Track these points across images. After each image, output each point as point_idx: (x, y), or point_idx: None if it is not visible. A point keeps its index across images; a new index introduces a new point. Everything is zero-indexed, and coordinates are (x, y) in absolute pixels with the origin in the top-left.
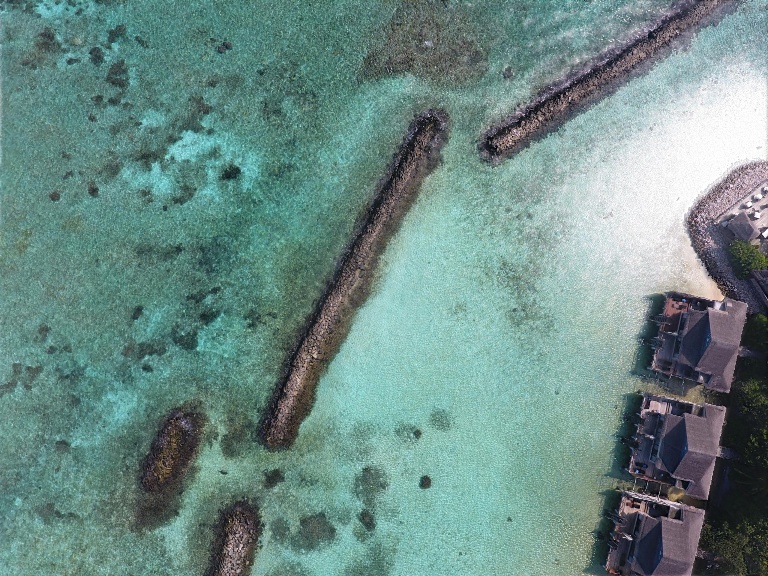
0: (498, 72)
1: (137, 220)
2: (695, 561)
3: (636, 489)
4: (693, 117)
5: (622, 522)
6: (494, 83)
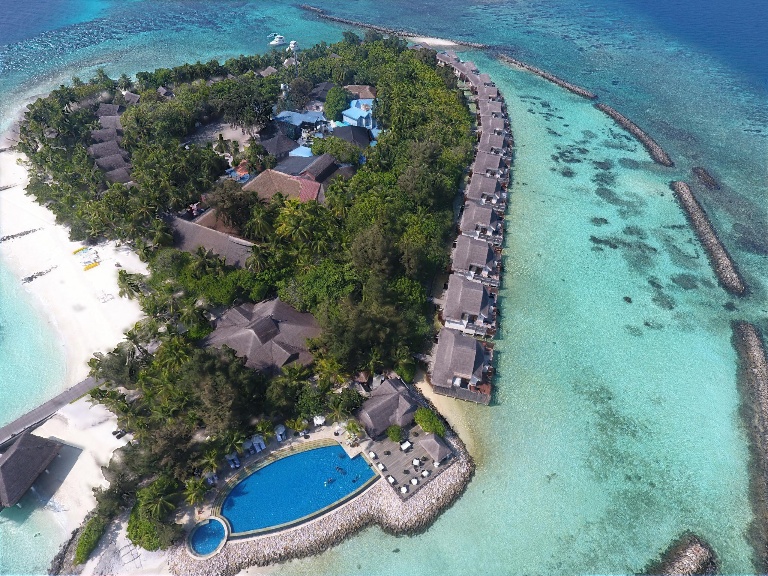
0: None
1: None
2: None
3: None
4: None
5: None
6: None
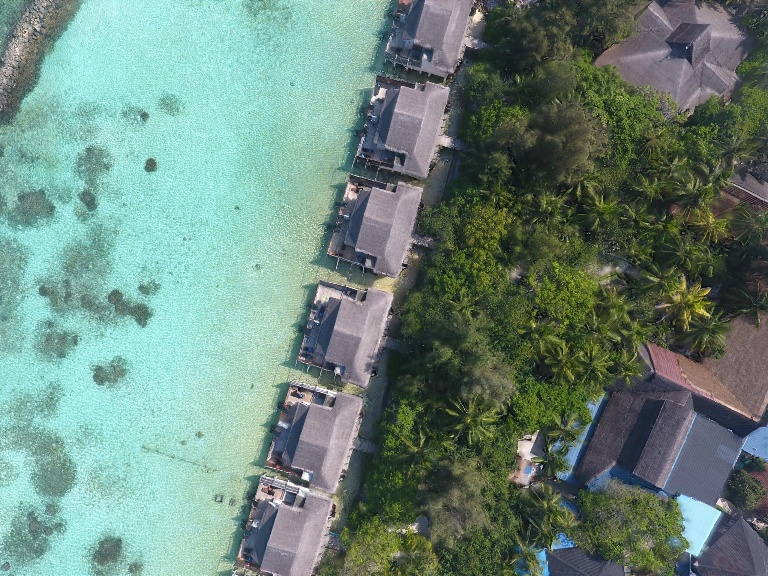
0: None
1: None
2: None
3: None
4: None
5: None
6: None
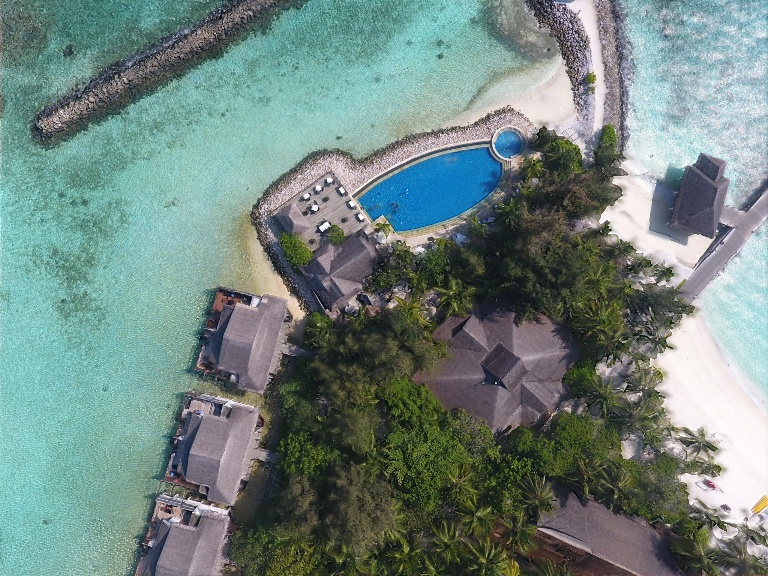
0: (57, 50)
1: None
2: None
3: None
4: (269, 103)
5: (155, 528)
6: (52, 61)
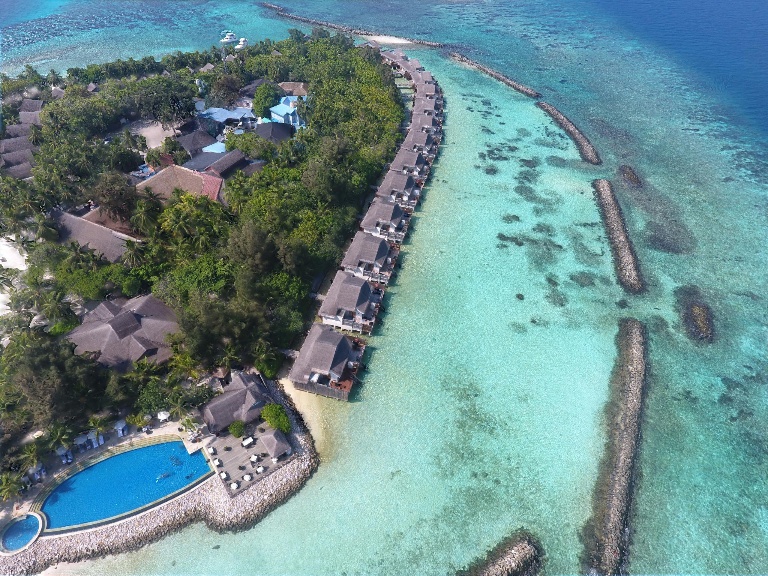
0: None
1: None
2: None
3: None
4: None
5: (390, 268)
6: None
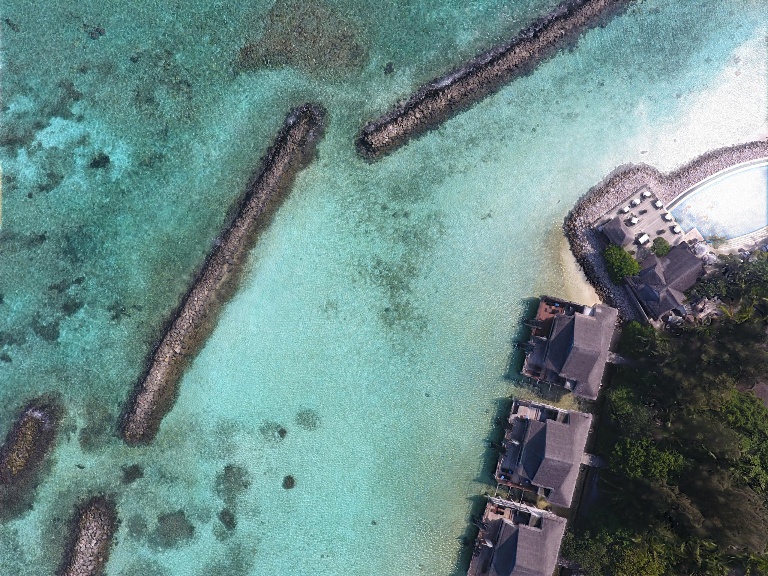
0: (379, 67)
1: (1, 207)
2: (562, 570)
3: (505, 495)
4: (577, 119)
5: (486, 528)
6: (374, 78)
